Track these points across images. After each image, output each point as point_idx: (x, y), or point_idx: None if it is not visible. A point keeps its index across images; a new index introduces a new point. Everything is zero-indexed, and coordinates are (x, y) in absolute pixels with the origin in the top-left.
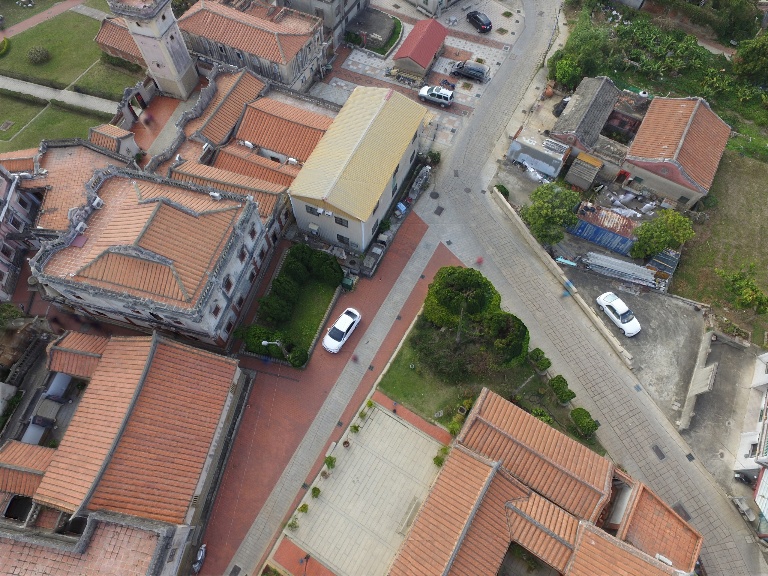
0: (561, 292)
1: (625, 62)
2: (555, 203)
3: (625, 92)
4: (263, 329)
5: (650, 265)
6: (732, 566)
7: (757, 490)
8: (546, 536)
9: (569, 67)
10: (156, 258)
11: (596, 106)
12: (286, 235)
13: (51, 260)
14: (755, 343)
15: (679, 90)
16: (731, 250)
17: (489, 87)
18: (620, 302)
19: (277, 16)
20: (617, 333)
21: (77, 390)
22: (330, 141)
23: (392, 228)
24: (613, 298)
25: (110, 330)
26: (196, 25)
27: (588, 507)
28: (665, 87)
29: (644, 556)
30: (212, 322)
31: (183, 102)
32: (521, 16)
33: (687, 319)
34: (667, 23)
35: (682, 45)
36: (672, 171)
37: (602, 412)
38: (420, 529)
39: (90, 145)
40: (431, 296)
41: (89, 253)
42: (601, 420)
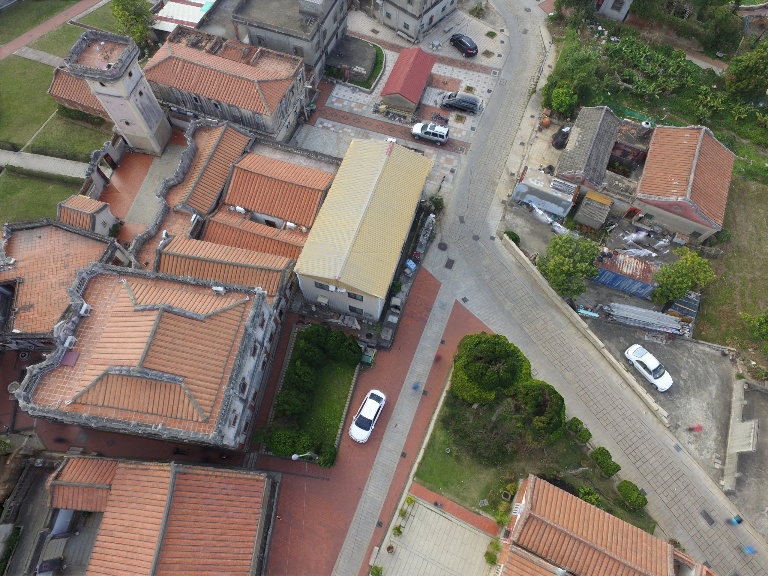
0: (587, 347)
1: (619, 85)
2: (576, 257)
3: (626, 121)
4: (288, 434)
5: (672, 310)
6: None
7: None
8: None
9: (566, 96)
10: (164, 378)
11: (599, 139)
12: (291, 307)
13: (40, 385)
14: None
15: (674, 111)
16: (747, 284)
17: (483, 118)
18: (650, 356)
19: (254, 58)
20: (649, 388)
21: (83, 518)
22: (333, 207)
23: (404, 288)
24: (642, 352)
25: (111, 439)
26: (165, 74)
27: None
28: (660, 108)
29: None
30: (231, 433)
31: (157, 158)
32: (505, 36)
33: (716, 366)
34: (655, 39)
35: (673, 63)
36: (685, 209)
37: (646, 479)
38: None
39: (62, 225)
40: (459, 371)
41: (84, 374)
42: (646, 488)
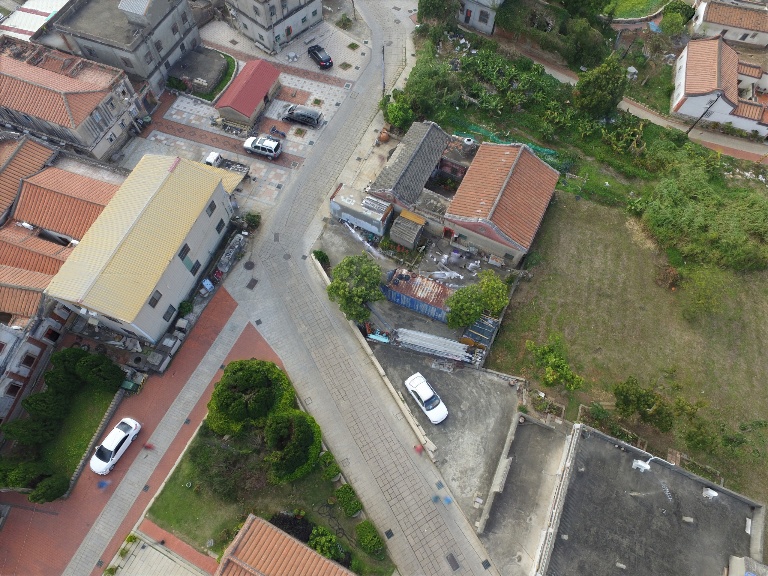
0: (371, 374)
1: (464, 99)
2: (353, 281)
3: (454, 138)
4: None
5: (466, 336)
6: None
7: None
8: None
9: (399, 111)
10: None
11: (420, 156)
12: (74, 327)
13: None
14: (568, 419)
15: (522, 126)
16: (556, 309)
17: (324, 132)
18: (425, 386)
19: (72, 69)
20: (424, 420)
21: None
22: (102, 225)
23: (196, 309)
24: (419, 382)
25: None
26: None
27: None
28: (507, 124)
29: None
30: None
31: None
32: (368, 47)
33: (500, 397)
34: (512, 52)
35: (525, 77)
36: (489, 230)
37: (397, 519)
38: None
39: None
40: (212, 400)
41: None
42: (395, 529)
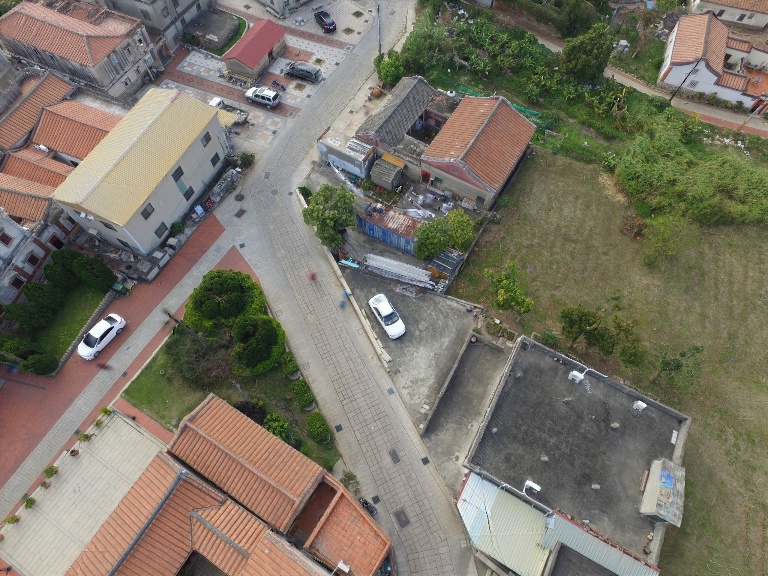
0: (339, 294)
1: (455, 61)
2: (326, 205)
3: (439, 91)
4: None
5: (431, 266)
6: (439, 571)
7: (460, 494)
8: (226, 545)
9: (391, 67)
10: None
11: (405, 106)
12: (77, 240)
13: None
14: None
15: (509, 89)
16: (521, 250)
17: (322, 88)
18: (386, 304)
19: (96, 18)
20: (383, 335)
21: None
22: (106, 144)
23: (187, 231)
24: (381, 300)
25: None
26: (9, 28)
27: (281, 514)
28: (495, 86)
29: (305, 564)
30: None
31: None
32: (371, 16)
33: (457, 320)
34: (506, 22)
35: (516, 44)
36: (460, 171)
37: (347, 416)
38: (98, 540)
39: None
40: (189, 300)
41: None
42: (344, 424)
